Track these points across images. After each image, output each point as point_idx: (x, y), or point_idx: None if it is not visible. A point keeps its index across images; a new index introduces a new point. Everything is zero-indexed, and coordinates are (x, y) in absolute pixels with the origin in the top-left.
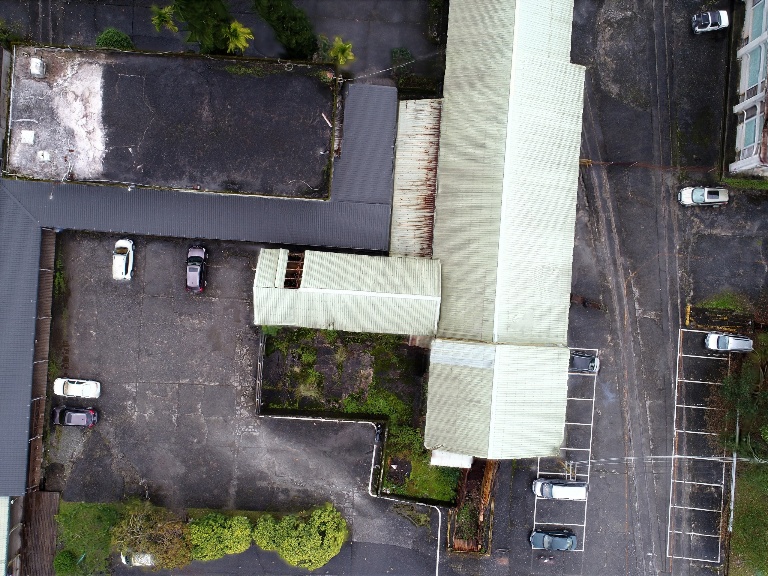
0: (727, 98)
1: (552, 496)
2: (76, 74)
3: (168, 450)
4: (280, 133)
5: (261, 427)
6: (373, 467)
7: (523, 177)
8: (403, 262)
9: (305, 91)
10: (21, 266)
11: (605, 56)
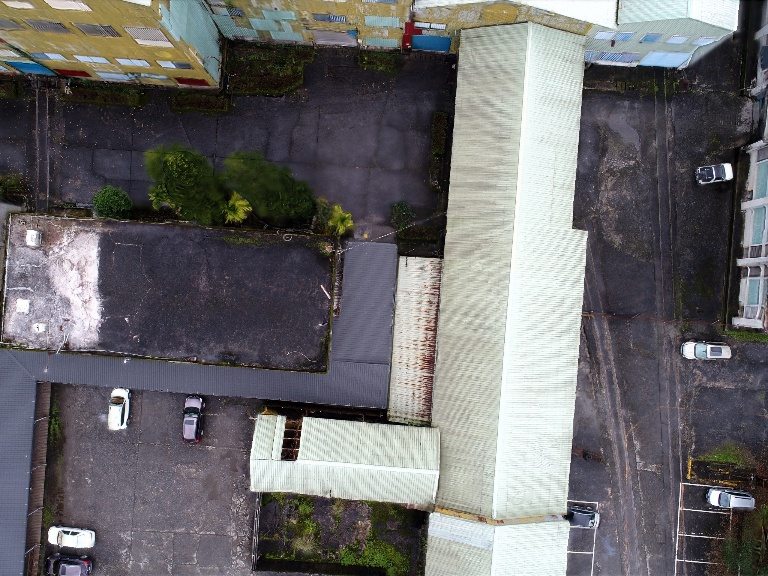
0: (731, 250)
1: None
2: (72, 242)
3: None
4: (278, 304)
5: None
6: None
7: (524, 349)
8: (402, 430)
9: (304, 262)
10: (16, 421)
11: (608, 206)
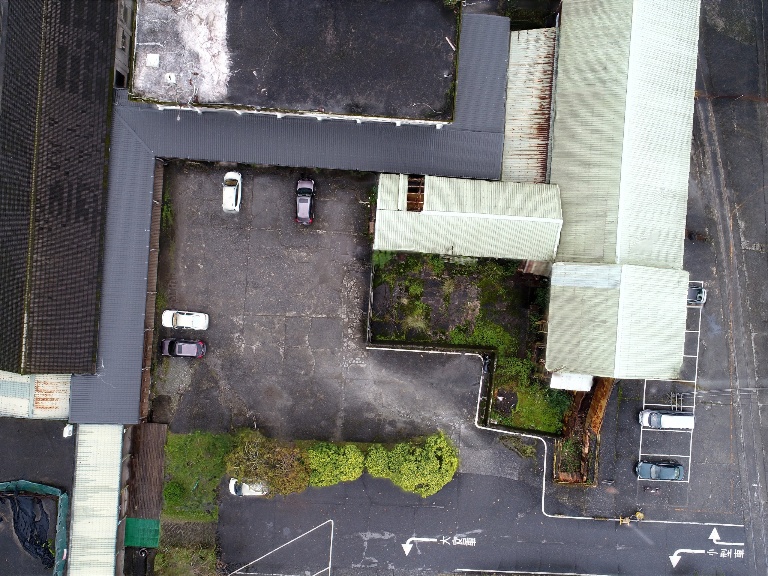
0: None
1: (661, 425)
2: None
3: (275, 382)
4: (404, 56)
5: (368, 359)
6: (480, 399)
7: (644, 101)
8: (522, 187)
9: (429, 15)
10: (135, 195)
11: None
